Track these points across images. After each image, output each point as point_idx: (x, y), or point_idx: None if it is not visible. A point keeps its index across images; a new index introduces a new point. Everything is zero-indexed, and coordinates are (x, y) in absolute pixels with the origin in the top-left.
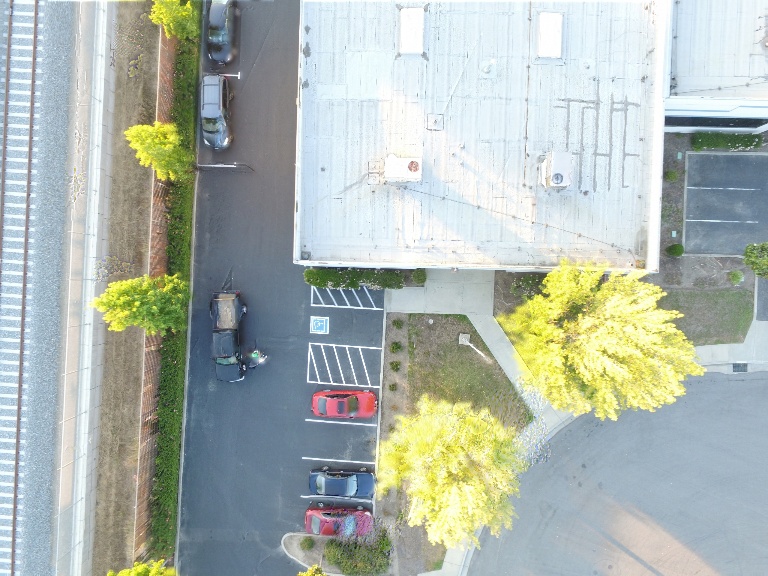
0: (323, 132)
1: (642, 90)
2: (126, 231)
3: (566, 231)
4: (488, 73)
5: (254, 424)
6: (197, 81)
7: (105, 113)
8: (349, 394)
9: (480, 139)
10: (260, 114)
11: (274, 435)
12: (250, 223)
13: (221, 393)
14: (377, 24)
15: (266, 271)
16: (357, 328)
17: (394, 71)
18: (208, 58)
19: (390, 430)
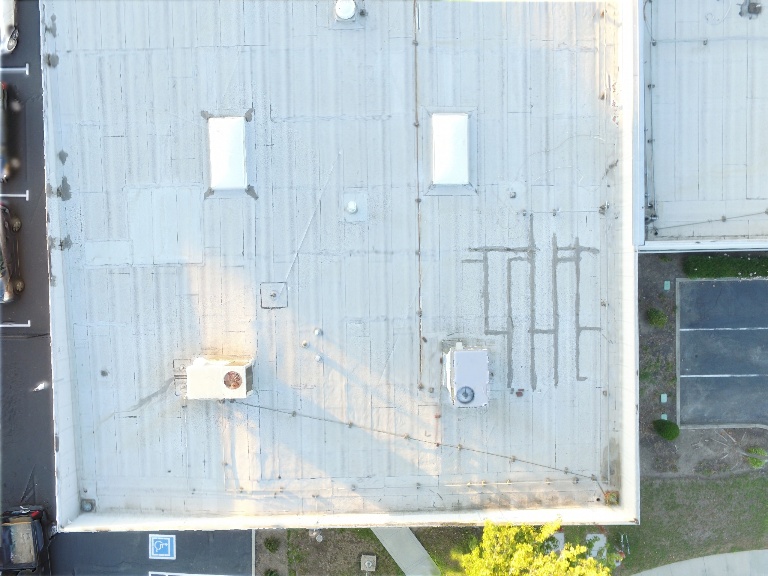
0: (100, 316)
1: (601, 227)
2: None
3: (491, 454)
4: (354, 213)
5: None
6: None
7: None
8: None
9: (347, 318)
10: None
11: None
12: None
13: None
14: (173, 144)
15: None
16: (215, 550)
17: (204, 217)
18: None
19: None
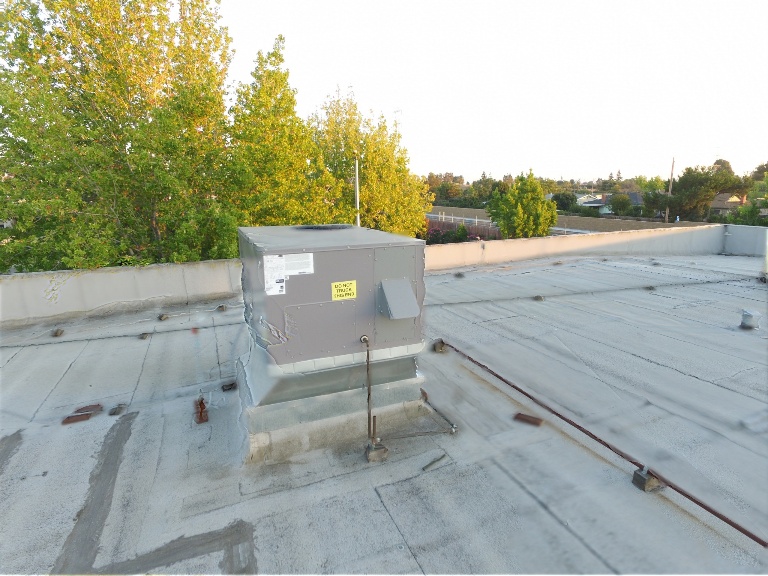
0: None
1: None
2: None
3: (204, 327)
4: None
5: None
6: None
7: None
8: None
9: None
10: None
11: None
12: None
13: None
14: None
15: None
16: None
17: None
18: None
19: None
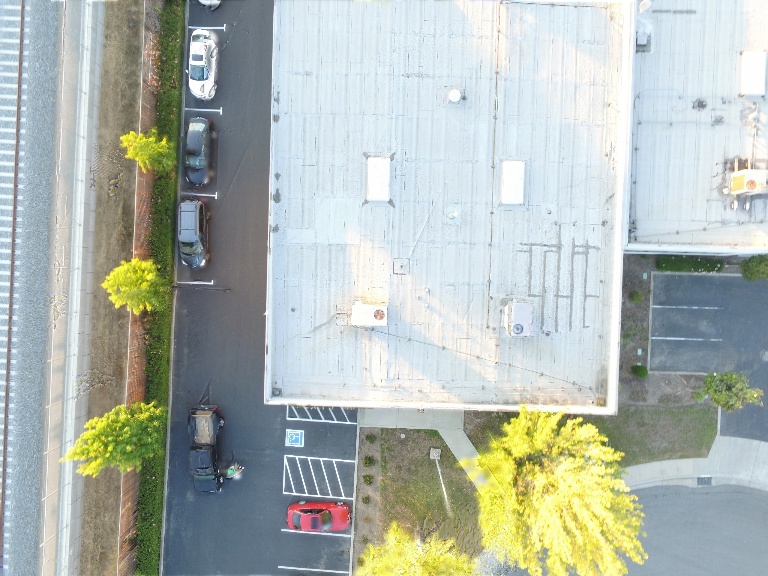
0: (293, 274)
1: (602, 234)
2: (107, 345)
3: (529, 370)
4: (453, 219)
5: (231, 533)
6: (175, 202)
7: (85, 235)
8: (323, 509)
9: (445, 282)
10: (237, 233)
11: (251, 544)
12: (227, 339)
13: (199, 503)
14: (345, 172)
15: (243, 385)
16: (331, 441)
17: (361, 217)
18: (186, 180)
19: (363, 541)
